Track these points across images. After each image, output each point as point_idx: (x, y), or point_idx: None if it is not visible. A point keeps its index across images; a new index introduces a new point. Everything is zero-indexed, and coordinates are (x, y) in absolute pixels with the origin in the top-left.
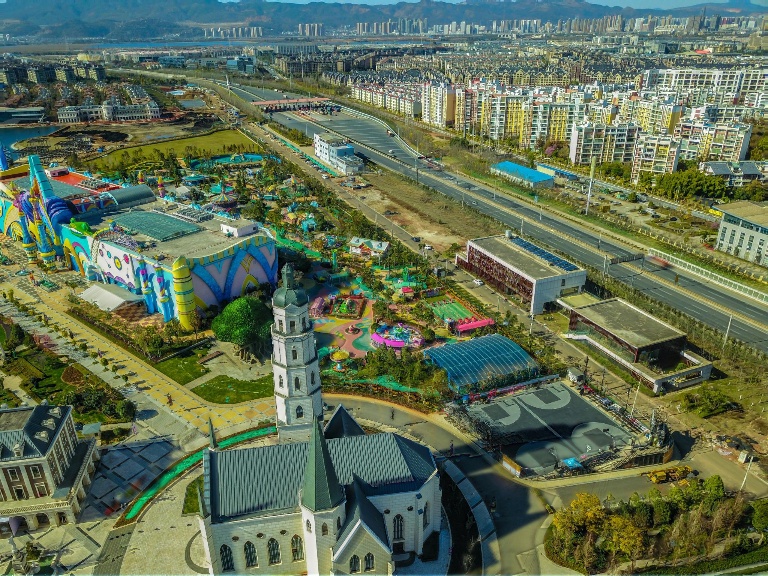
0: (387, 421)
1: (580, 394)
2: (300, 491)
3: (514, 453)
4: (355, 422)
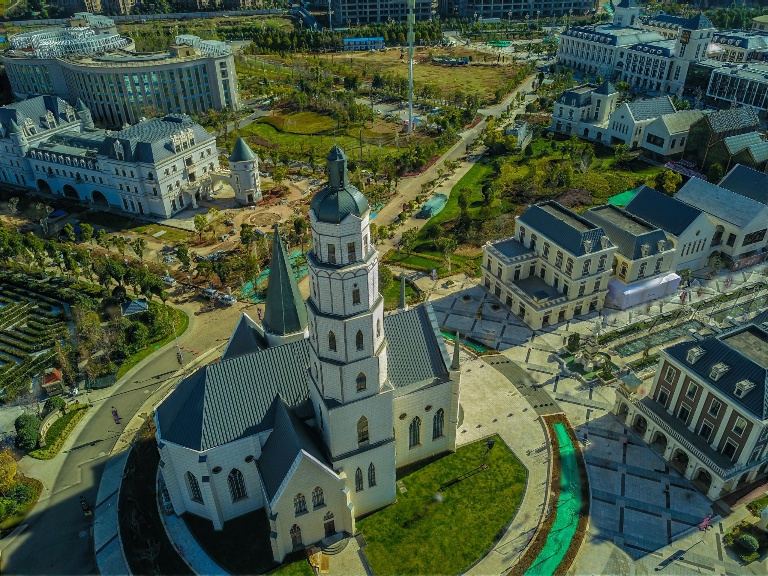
0: None
1: None
2: None
3: None
4: (283, 482)
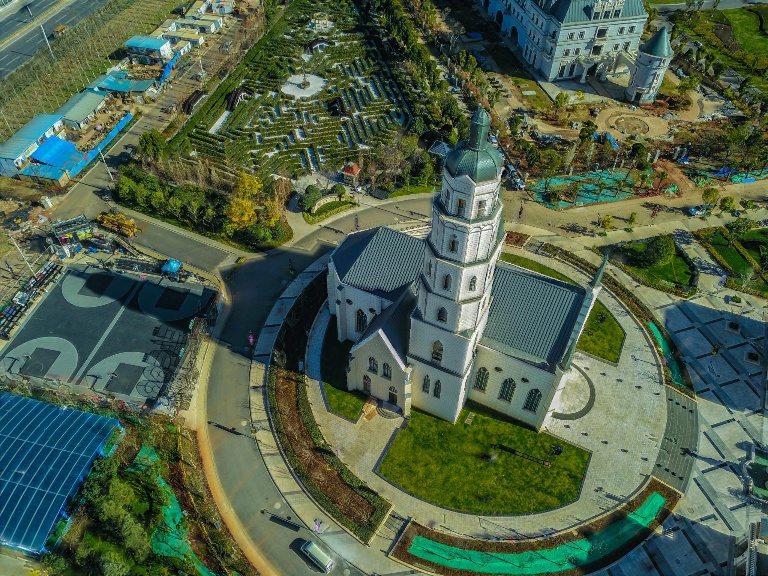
0: (253, 458)
1: (8, 339)
2: (500, 244)
3: (190, 318)
4: None
